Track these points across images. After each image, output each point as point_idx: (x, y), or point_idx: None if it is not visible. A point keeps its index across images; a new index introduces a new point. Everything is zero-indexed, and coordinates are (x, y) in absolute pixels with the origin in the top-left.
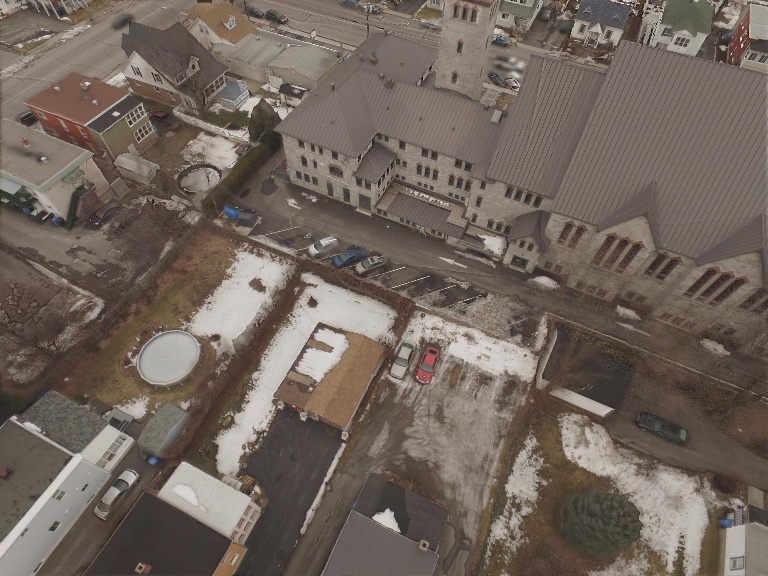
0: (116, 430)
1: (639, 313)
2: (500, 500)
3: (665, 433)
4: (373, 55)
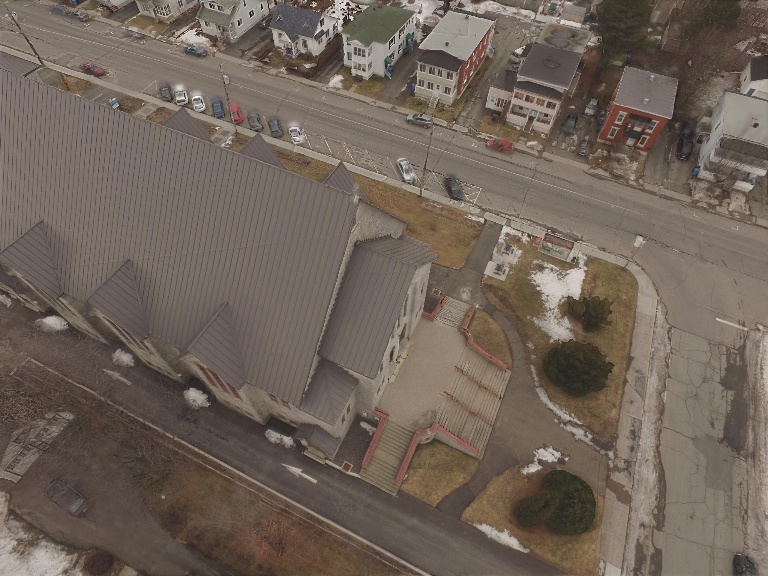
0: None
1: (136, 358)
2: None
3: (58, 503)
4: None
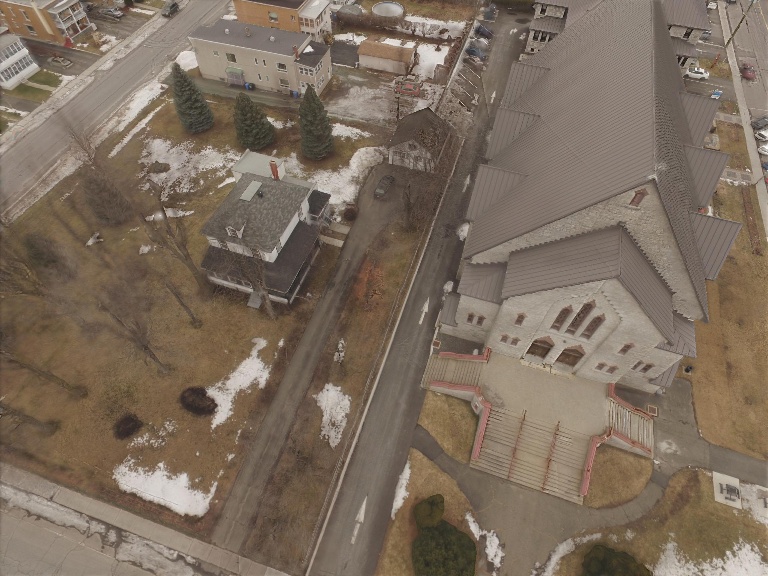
0: None
1: None
2: (331, 121)
3: None
4: None
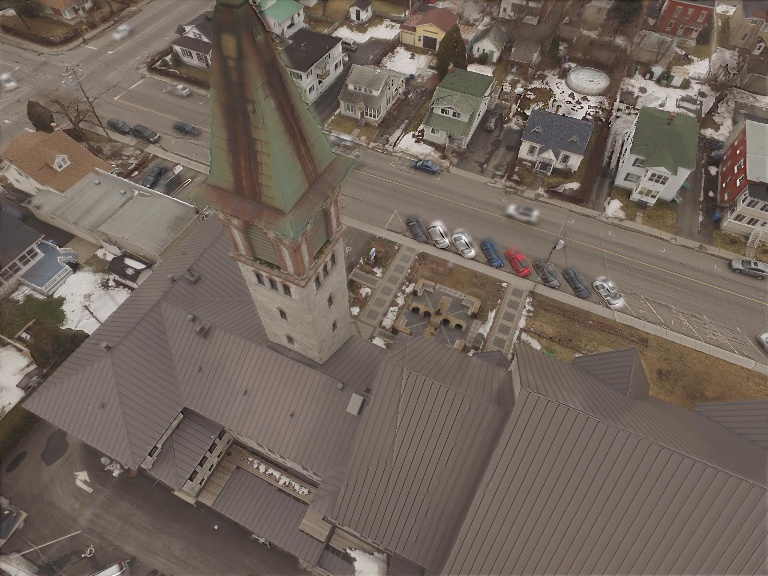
0: None
1: None
2: None
3: None
4: (189, 273)
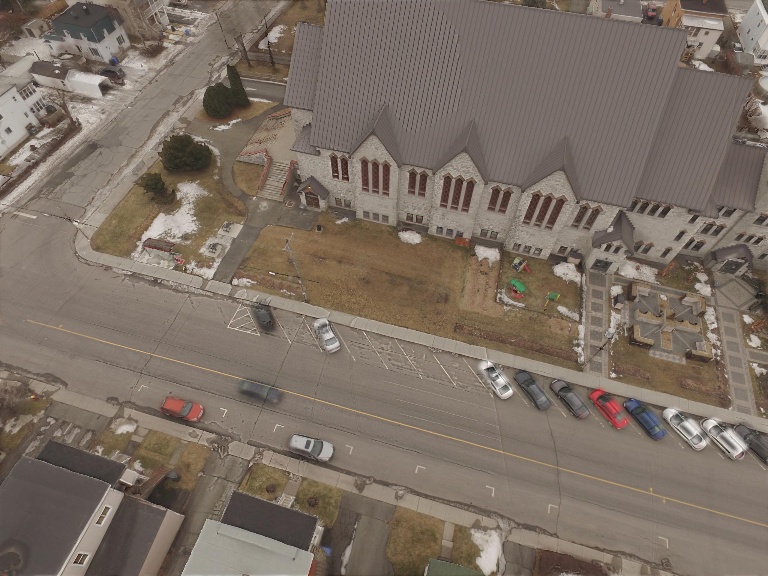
0: (765, 45)
1: None
2: None
3: None
4: None
